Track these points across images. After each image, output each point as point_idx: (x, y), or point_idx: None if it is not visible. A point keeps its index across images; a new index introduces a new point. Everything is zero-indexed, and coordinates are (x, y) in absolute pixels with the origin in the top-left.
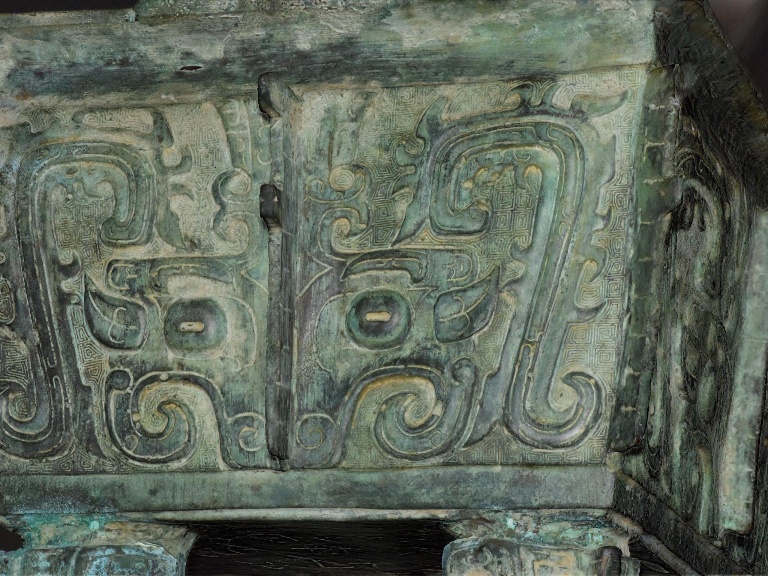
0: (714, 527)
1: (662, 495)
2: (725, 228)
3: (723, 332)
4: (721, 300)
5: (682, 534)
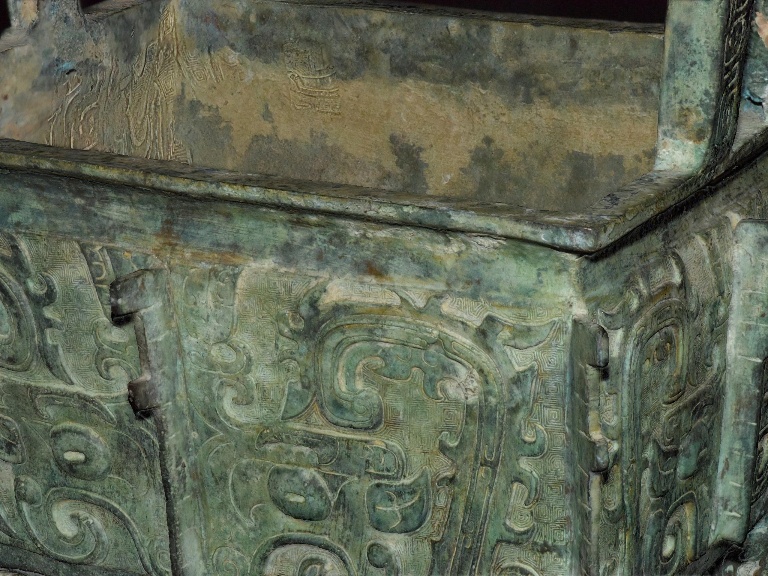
0: (164, 574)
1: (4, 540)
2: (35, 303)
3: (69, 399)
4: (56, 369)
5: (105, 573)
